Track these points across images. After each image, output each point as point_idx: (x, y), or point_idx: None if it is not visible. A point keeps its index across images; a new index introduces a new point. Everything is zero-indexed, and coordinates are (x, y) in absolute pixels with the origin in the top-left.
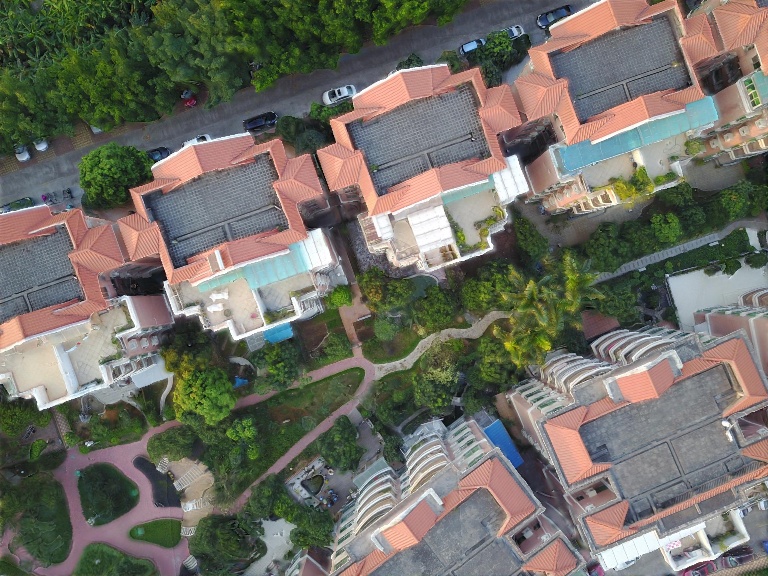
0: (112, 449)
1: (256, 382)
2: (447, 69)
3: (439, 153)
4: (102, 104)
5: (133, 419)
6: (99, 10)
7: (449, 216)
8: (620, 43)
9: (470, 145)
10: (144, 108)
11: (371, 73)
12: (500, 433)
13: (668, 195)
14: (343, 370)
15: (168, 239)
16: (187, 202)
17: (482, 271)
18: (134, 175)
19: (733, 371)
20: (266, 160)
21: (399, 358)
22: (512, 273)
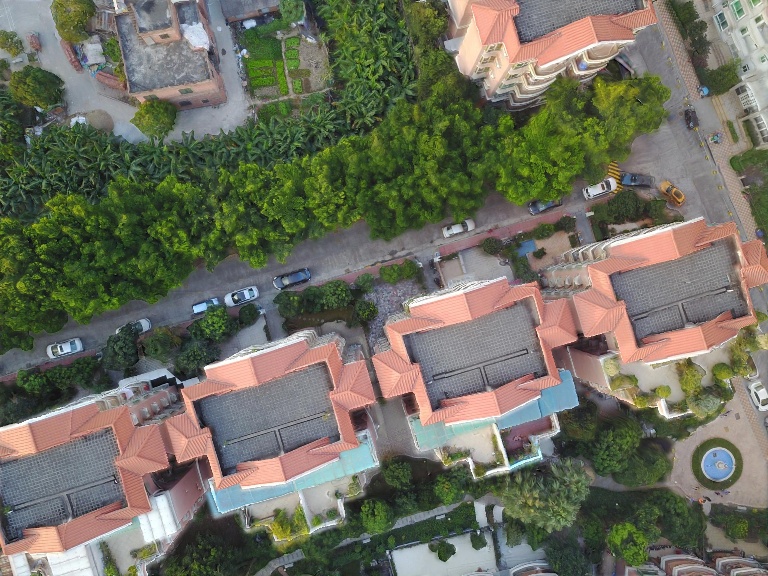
0: None
1: None
2: (94, 406)
3: (79, 495)
4: None
5: None
6: None
7: (104, 543)
8: (274, 388)
9: (112, 488)
10: None
11: (101, 326)
12: None
13: (385, 477)
14: None
15: None
16: None
17: (188, 550)
18: None
19: None
20: None
21: None
22: None
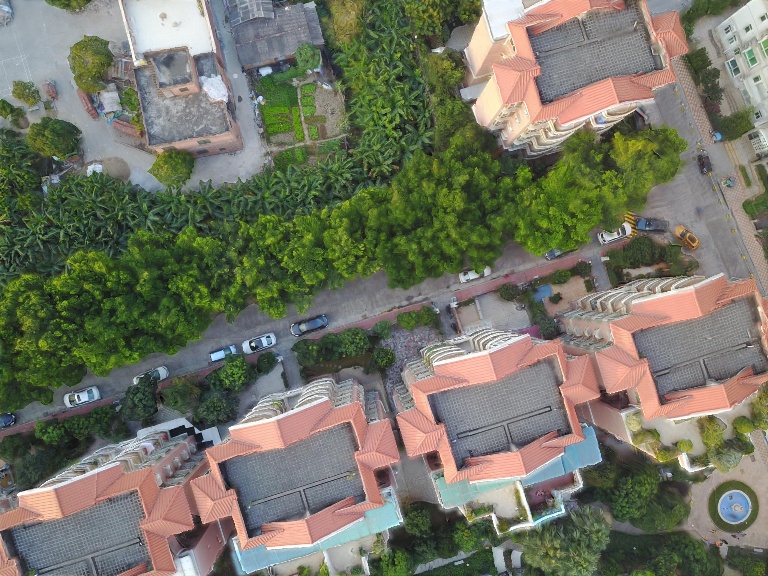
0: None
1: None
2: (119, 468)
3: (104, 558)
4: None
5: None
6: None
7: None
8: (299, 448)
9: (137, 550)
10: None
11: (118, 374)
12: None
13: (404, 525)
14: None
15: None
16: None
17: None
18: None
19: None
20: None
21: None
22: None
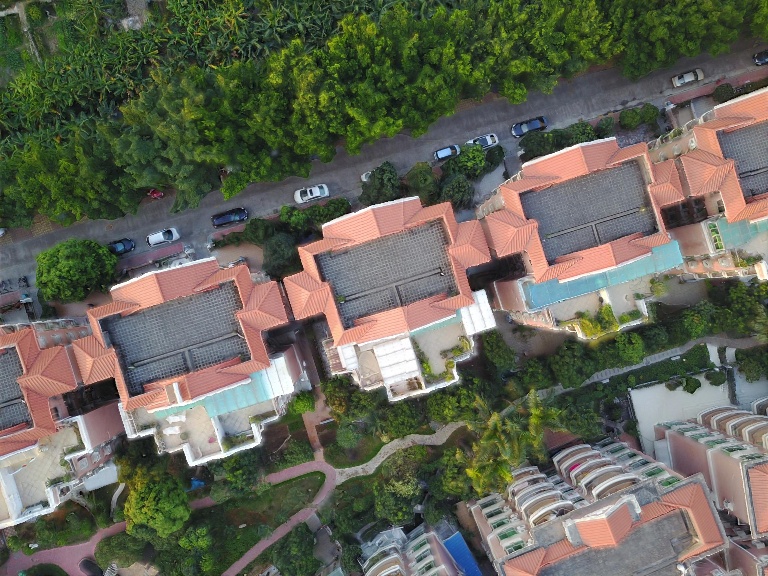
0: (58, 550)
1: (212, 489)
2: (419, 202)
3: (408, 286)
4: (64, 201)
5: (81, 521)
6: (66, 97)
7: (415, 344)
8: (590, 184)
9: (439, 279)
10: (108, 206)
11: (344, 173)
12: (459, 546)
13: None
14: (303, 474)
15: (125, 364)
16: (146, 326)
17: None
18: (94, 274)
19: (689, 517)
20: (231, 286)
21: (361, 463)
22: (477, 400)
